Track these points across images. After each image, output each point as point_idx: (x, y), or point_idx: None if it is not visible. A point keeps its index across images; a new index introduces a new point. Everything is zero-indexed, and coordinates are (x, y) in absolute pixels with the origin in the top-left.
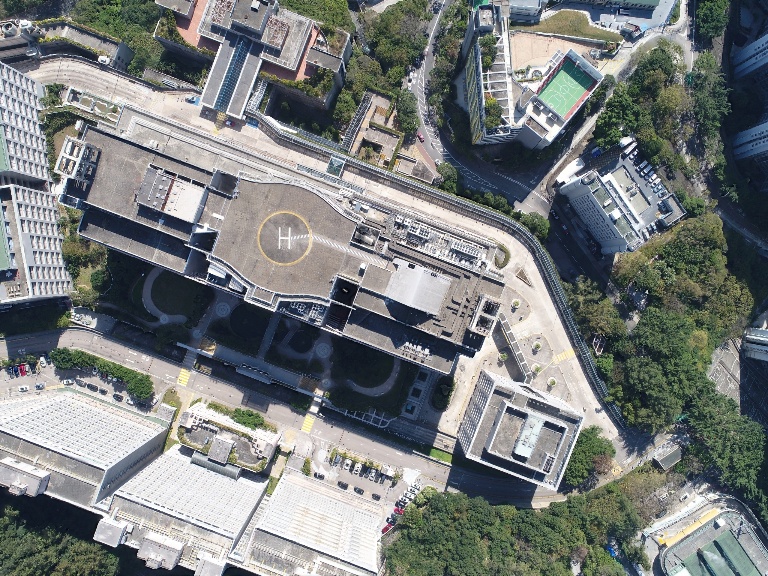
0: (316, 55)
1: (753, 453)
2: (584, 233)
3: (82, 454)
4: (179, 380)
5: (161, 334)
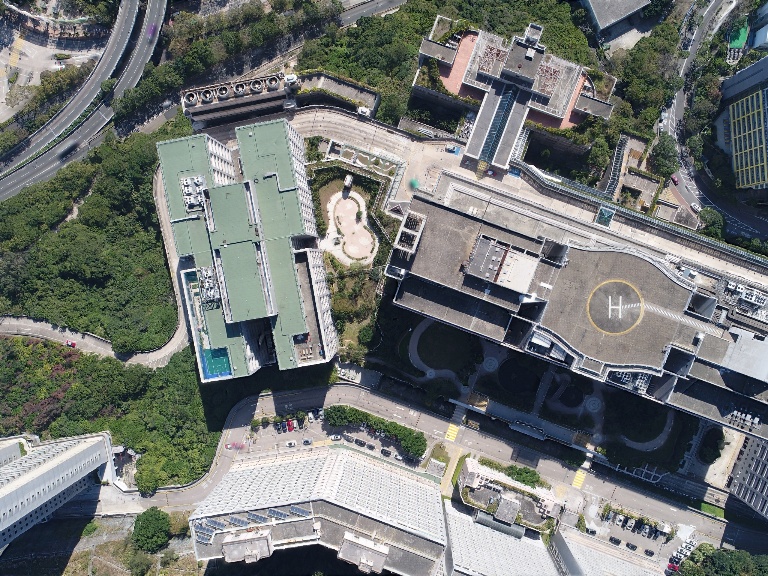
0: (585, 102)
1: None
2: None
3: (416, 528)
4: (447, 435)
5: (432, 390)
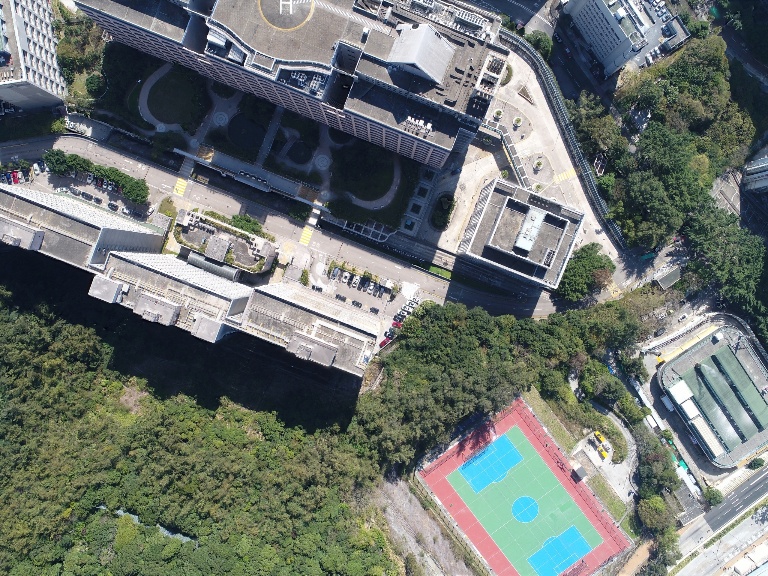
0: None
1: (753, 265)
2: (587, 55)
3: (77, 216)
4: (175, 190)
5: (158, 140)
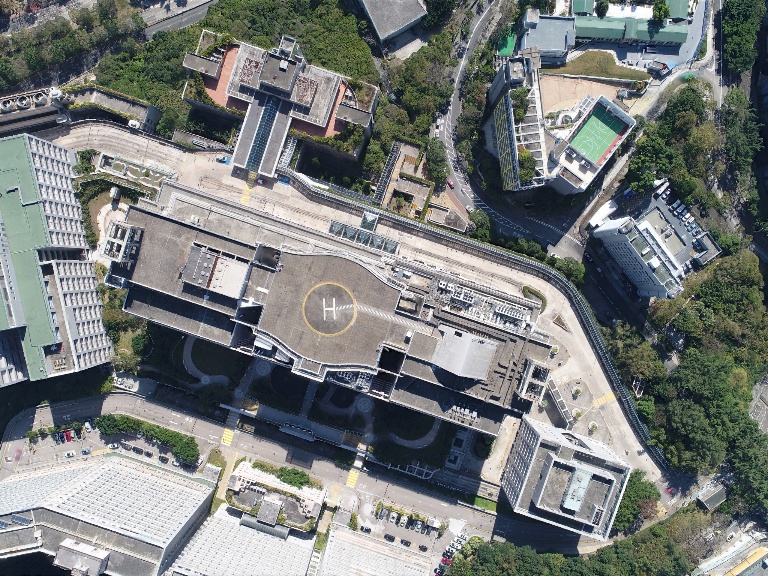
0: (345, 111)
1: None
2: (619, 275)
3: (139, 532)
4: (223, 440)
5: (204, 396)
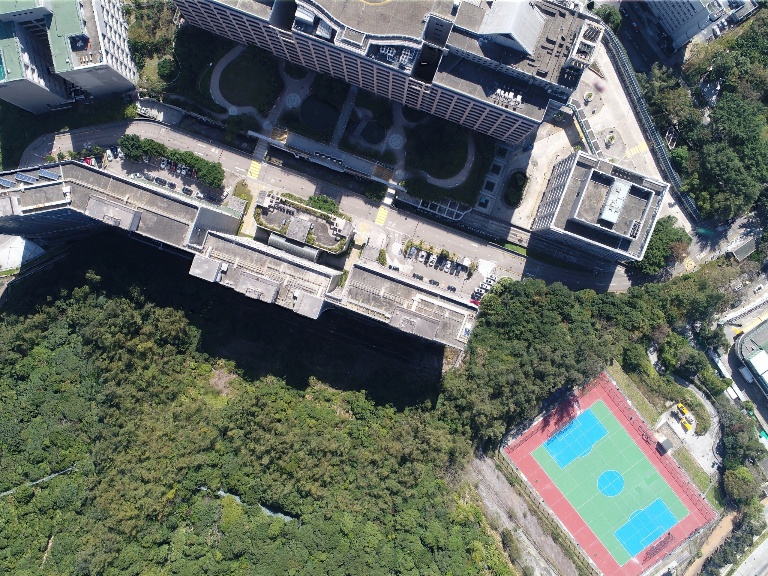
0: None
1: None
2: (655, 28)
3: None
4: (249, 173)
5: (231, 123)
